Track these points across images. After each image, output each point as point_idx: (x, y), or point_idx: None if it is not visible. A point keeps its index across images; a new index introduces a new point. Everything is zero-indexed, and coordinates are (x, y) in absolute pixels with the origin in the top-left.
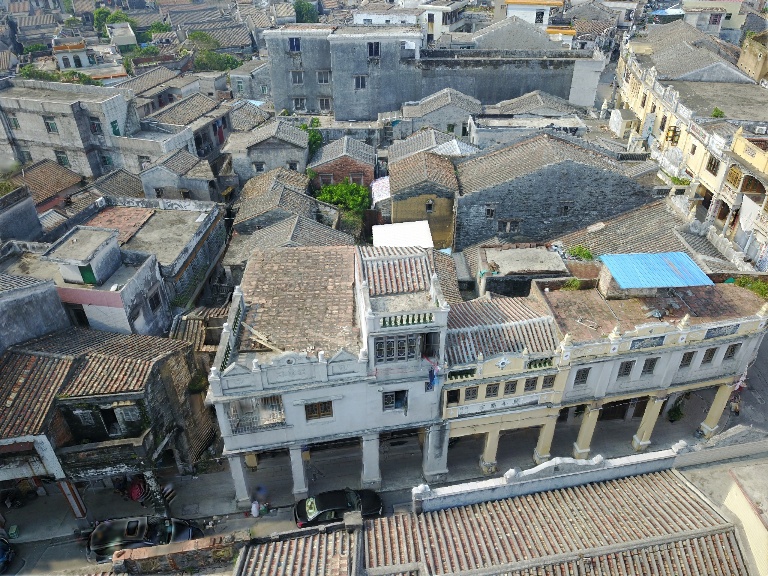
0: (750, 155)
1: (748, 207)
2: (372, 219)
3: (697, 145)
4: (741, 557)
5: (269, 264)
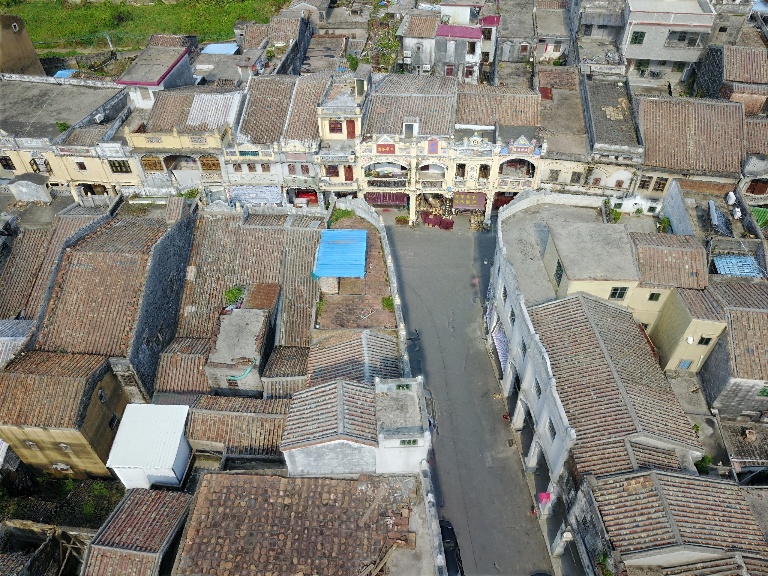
0: (156, 142)
1: (185, 176)
2: (7, 487)
3: (84, 161)
4: (593, 301)
5: (219, 574)
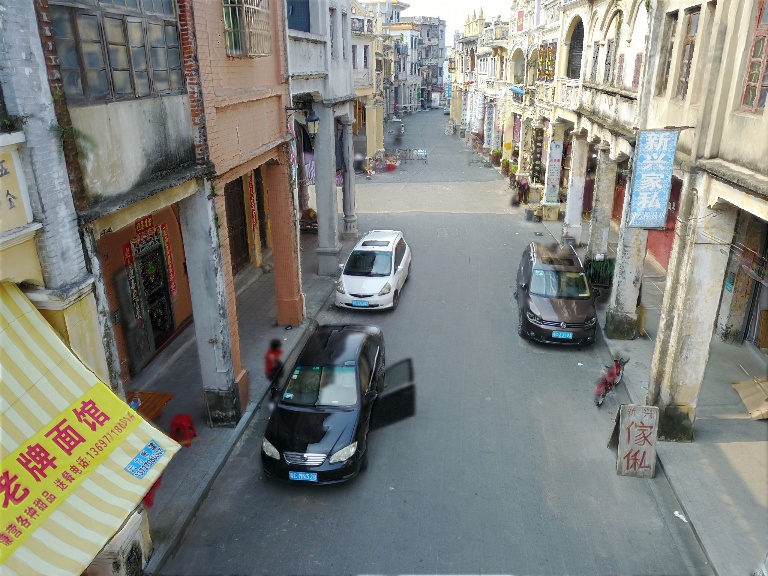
0: None
1: None
2: None
3: None
4: None
5: None
